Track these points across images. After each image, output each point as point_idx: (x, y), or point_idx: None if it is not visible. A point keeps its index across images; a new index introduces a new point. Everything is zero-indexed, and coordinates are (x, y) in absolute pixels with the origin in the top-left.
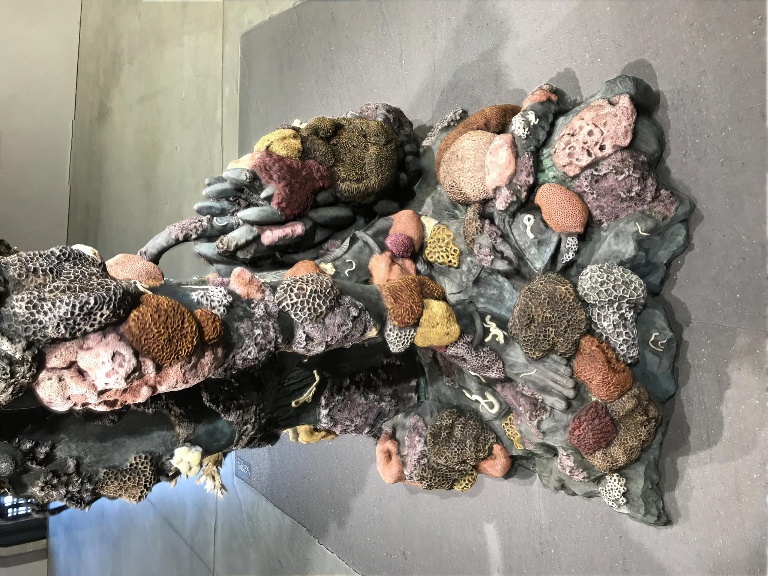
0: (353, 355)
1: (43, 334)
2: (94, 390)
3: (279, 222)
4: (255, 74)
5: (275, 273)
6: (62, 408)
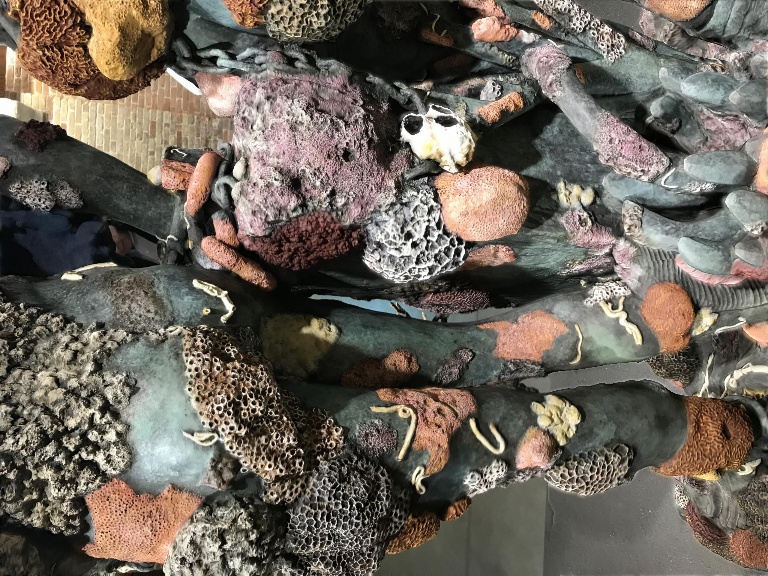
0: None
1: None
2: None
3: None
4: None
5: (657, 261)
6: None
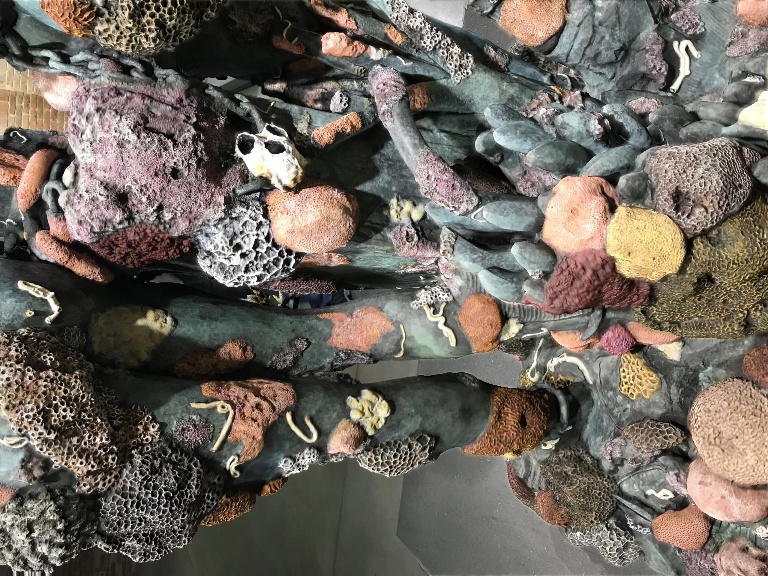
0: None
1: None
2: None
3: None
4: None
5: None
6: None
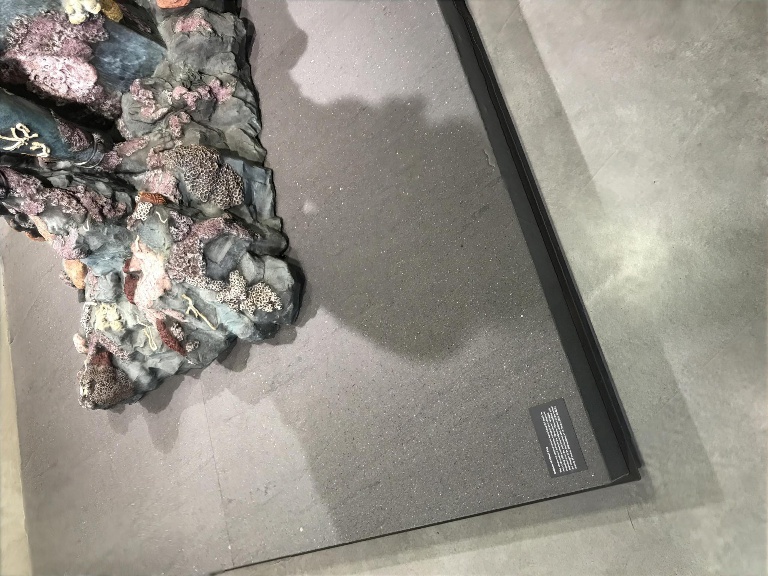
0: None
1: None
2: None
3: None
4: (61, 558)
5: None
6: None
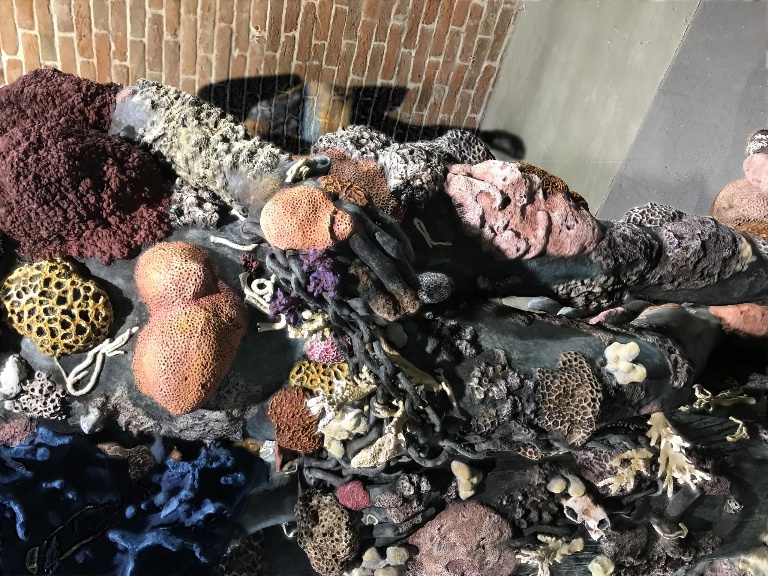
0: (767, 409)
1: (440, 151)
2: (495, 187)
3: (598, 311)
4: None
5: None
6: (474, 216)
